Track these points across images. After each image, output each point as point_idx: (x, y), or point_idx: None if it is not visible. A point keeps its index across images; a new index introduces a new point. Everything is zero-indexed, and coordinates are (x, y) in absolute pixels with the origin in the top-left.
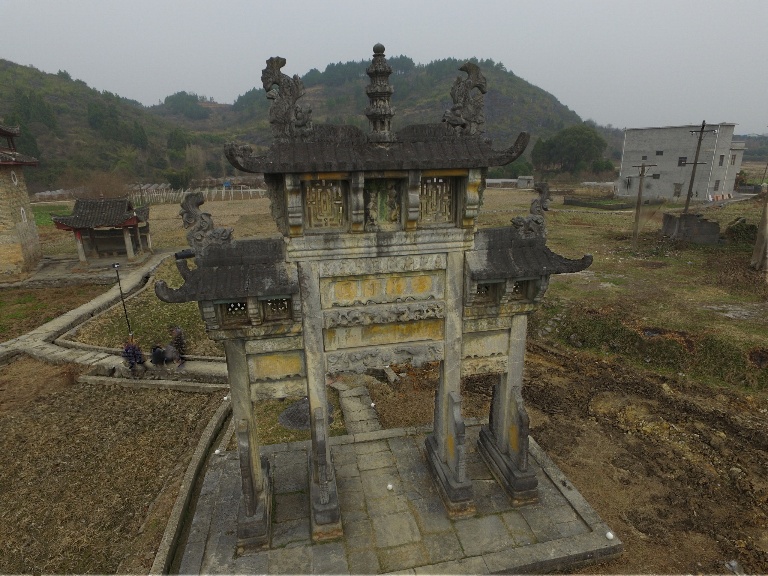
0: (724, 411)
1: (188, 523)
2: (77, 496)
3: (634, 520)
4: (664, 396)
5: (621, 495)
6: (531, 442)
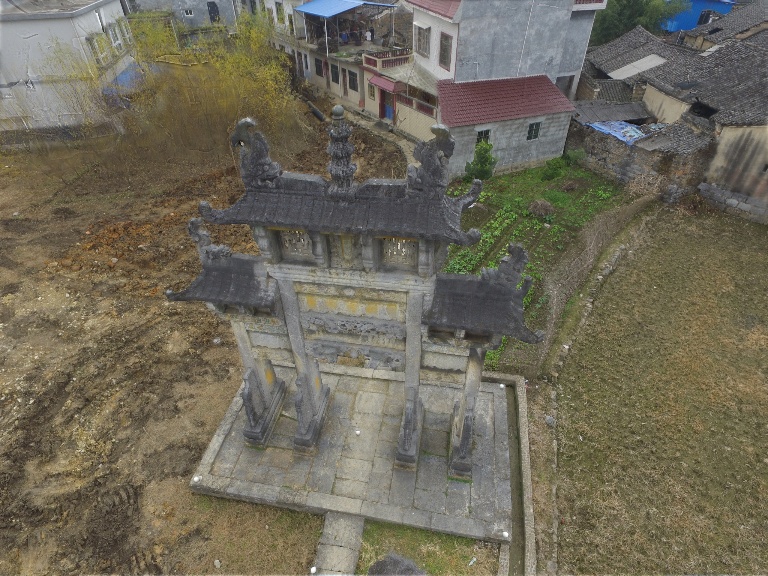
0: (4, 430)
1: (517, 484)
2: (647, 568)
3: (222, 378)
4: (7, 468)
5: (208, 390)
6: (217, 437)
